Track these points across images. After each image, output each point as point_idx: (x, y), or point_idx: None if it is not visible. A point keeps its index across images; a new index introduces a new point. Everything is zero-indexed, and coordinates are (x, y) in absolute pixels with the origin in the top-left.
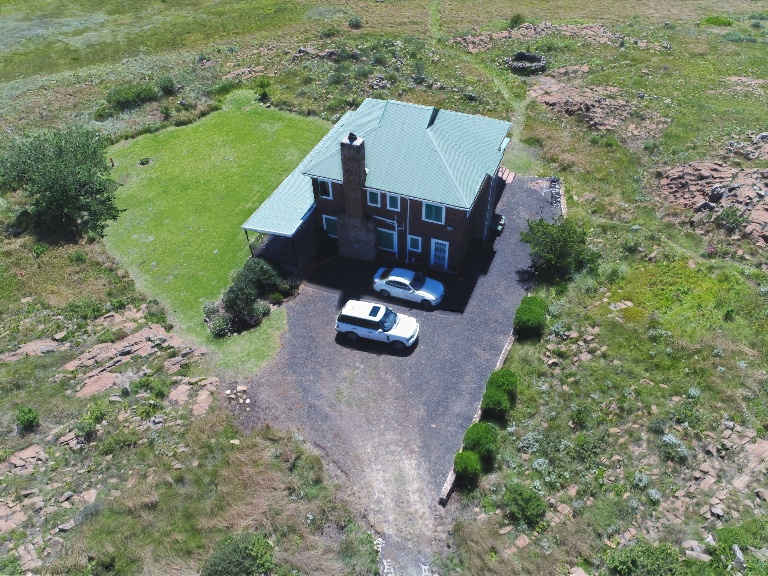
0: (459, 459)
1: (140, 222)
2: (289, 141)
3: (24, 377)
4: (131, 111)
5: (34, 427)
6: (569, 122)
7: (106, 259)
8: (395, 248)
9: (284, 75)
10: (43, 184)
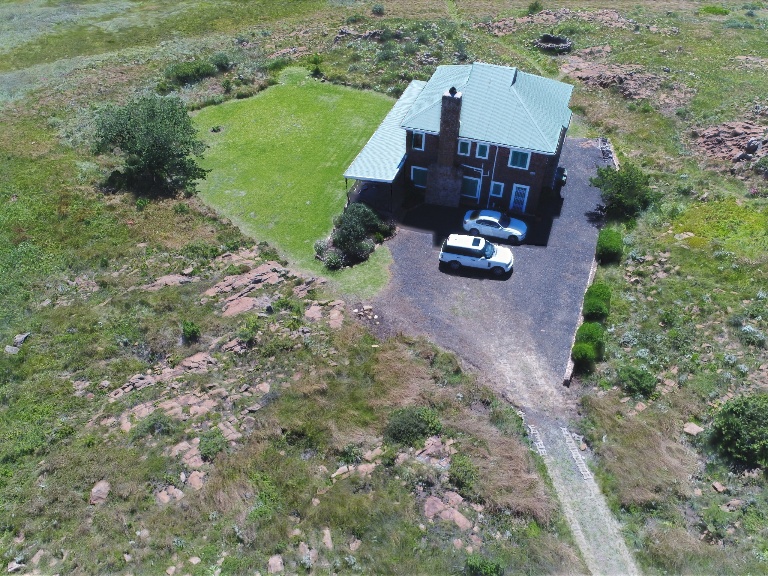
0: (578, 348)
1: (229, 180)
2: (351, 110)
3: (173, 301)
4: (191, 85)
5: (198, 338)
6: (604, 93)
7: (208, 210)
8: (477, 194)
9: (330, 54)
10: (146, 143)
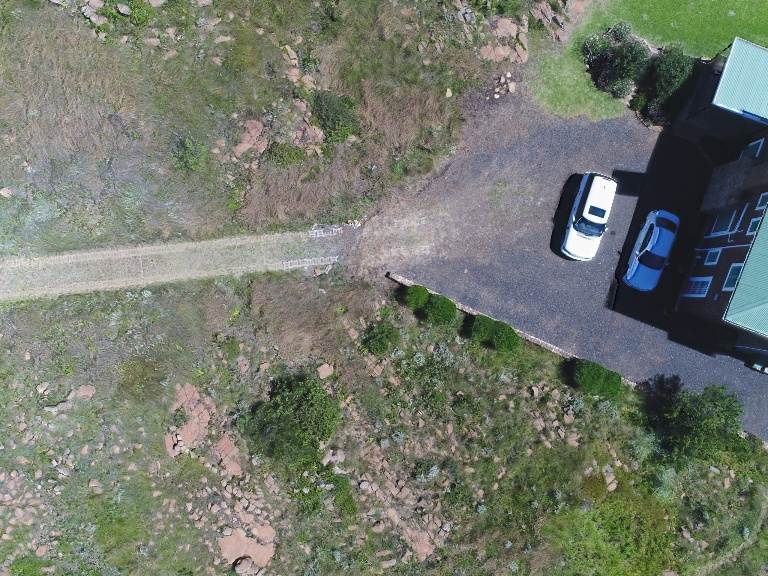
0: (417, 289)
1: None
2: None
3: None
4: None
5: None
6: None
7: None
8: (714, 234)
9: None
10: None
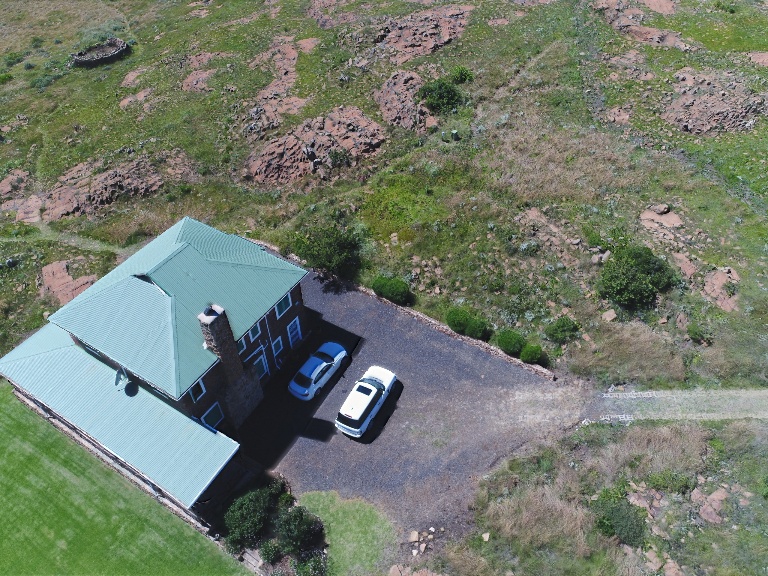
0: (532, 354)
1: None
2: None
3: None
4: None
5: None
6: (120, 207)
7: None
8: (266, 369)
9: None
10: None
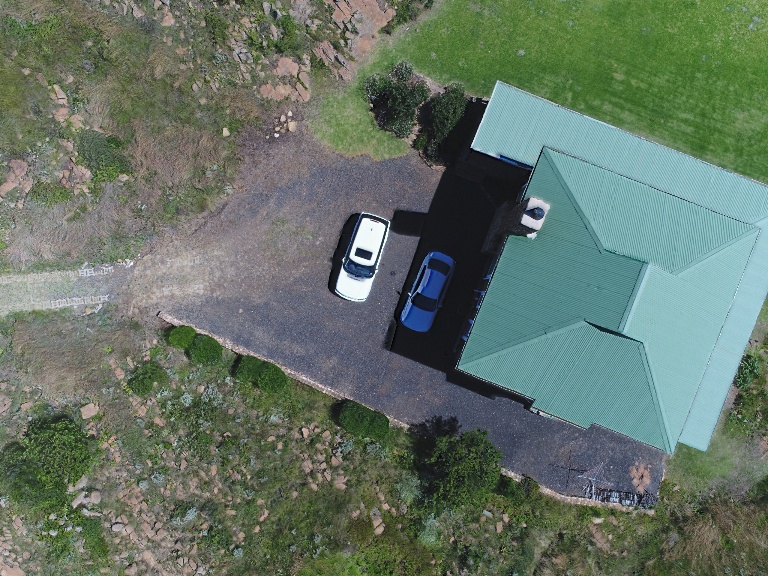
0: (180, 330)
1: None
2: None
3: None
4: None
5: None
6: None
7: None
8: None
9: None
10: None
